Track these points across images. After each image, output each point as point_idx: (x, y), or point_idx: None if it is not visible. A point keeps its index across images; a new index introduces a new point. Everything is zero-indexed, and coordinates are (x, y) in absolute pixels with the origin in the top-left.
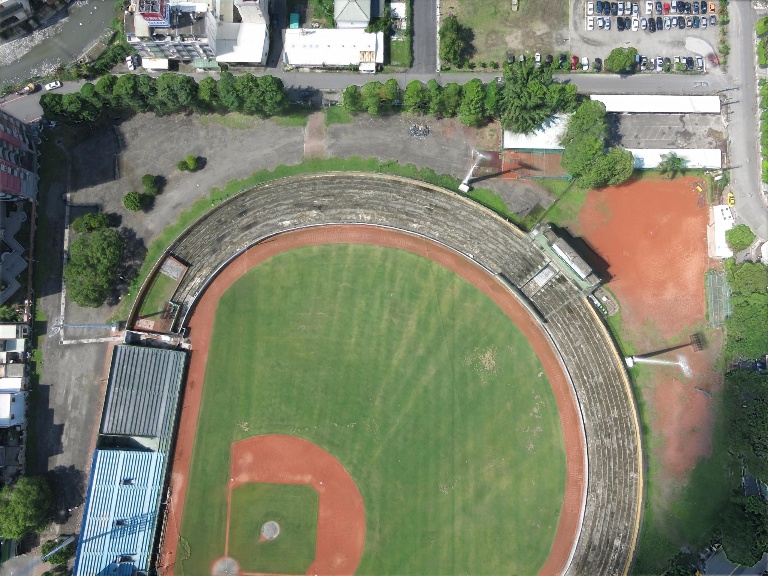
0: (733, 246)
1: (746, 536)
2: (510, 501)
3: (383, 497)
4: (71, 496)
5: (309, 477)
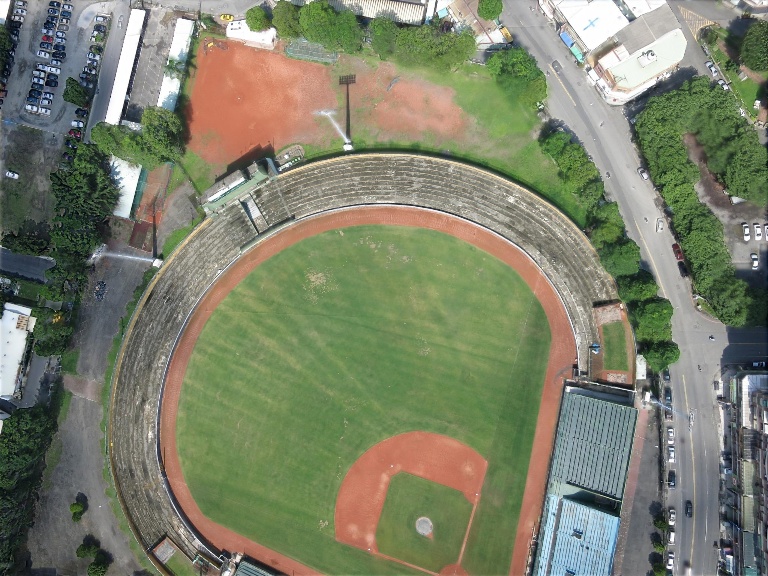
0: (264, 27)
1: (514, 83)
2: (451, 291)
3: (419, 411)
4: None
5: (384, 476)
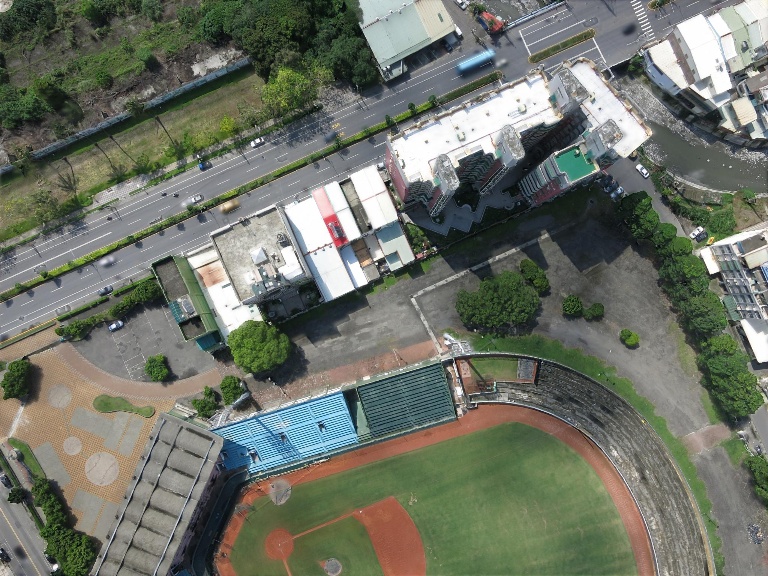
0: None
1: None
2: None
3: None
4: (282, 374)
5: None
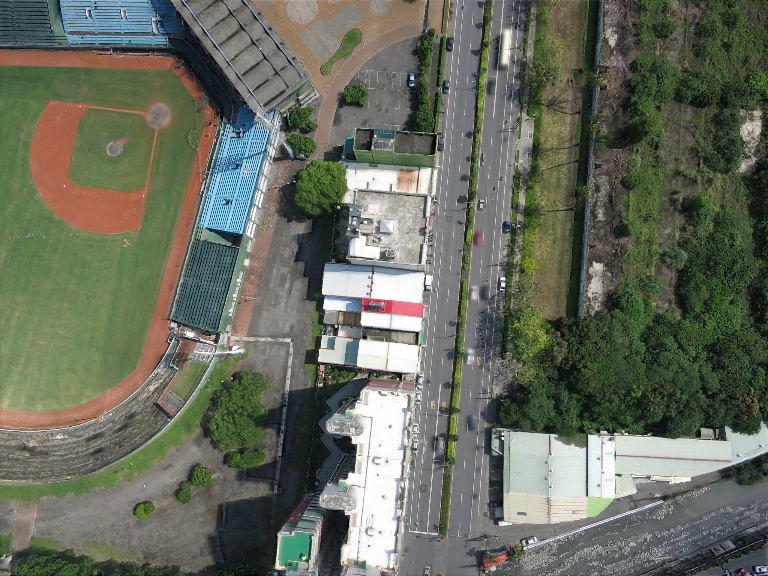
0: None
1: None
2: None
3: (12, 169)
4: (293, 194)
5: (75, 192)
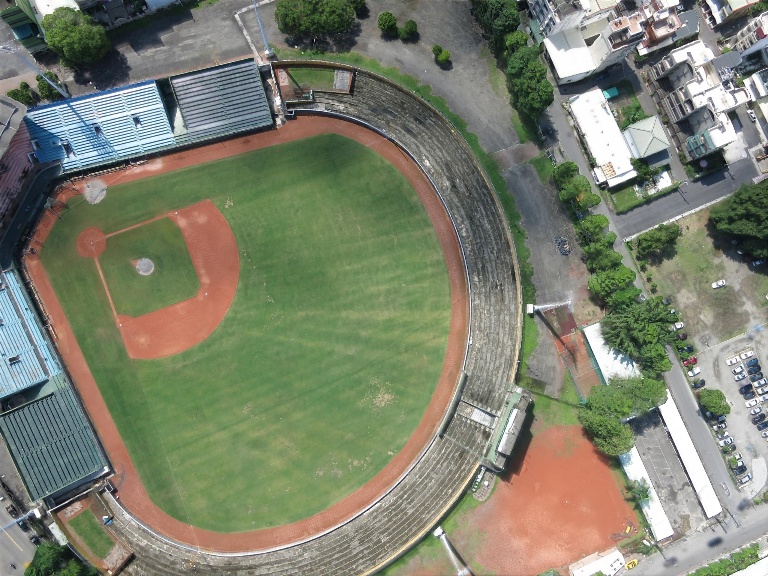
0: None
1: None
2: (262, 475)
3: (217, 356)
4: (103, 79)
5: (207, 281)
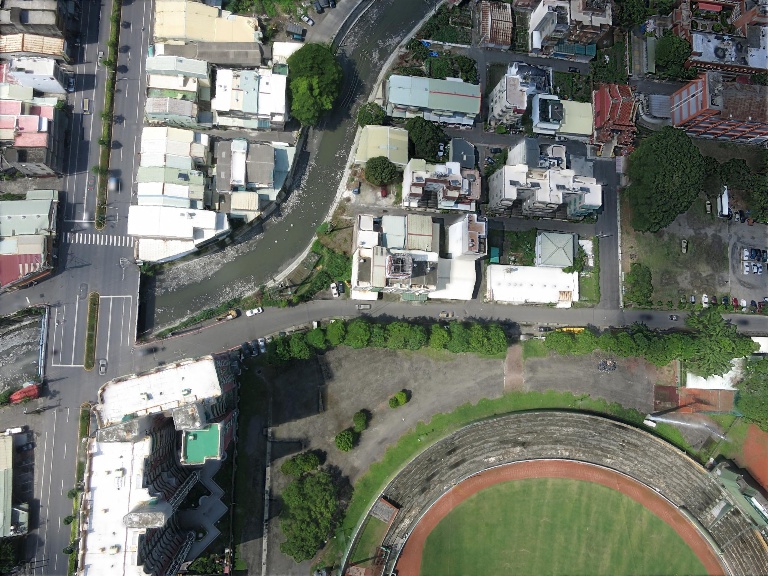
0: None
1: None
2: None
3: None
4: None
5: None
